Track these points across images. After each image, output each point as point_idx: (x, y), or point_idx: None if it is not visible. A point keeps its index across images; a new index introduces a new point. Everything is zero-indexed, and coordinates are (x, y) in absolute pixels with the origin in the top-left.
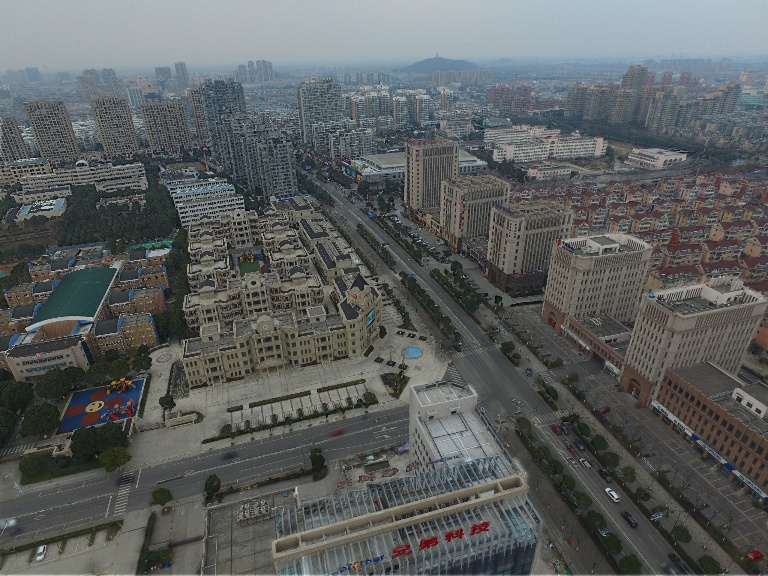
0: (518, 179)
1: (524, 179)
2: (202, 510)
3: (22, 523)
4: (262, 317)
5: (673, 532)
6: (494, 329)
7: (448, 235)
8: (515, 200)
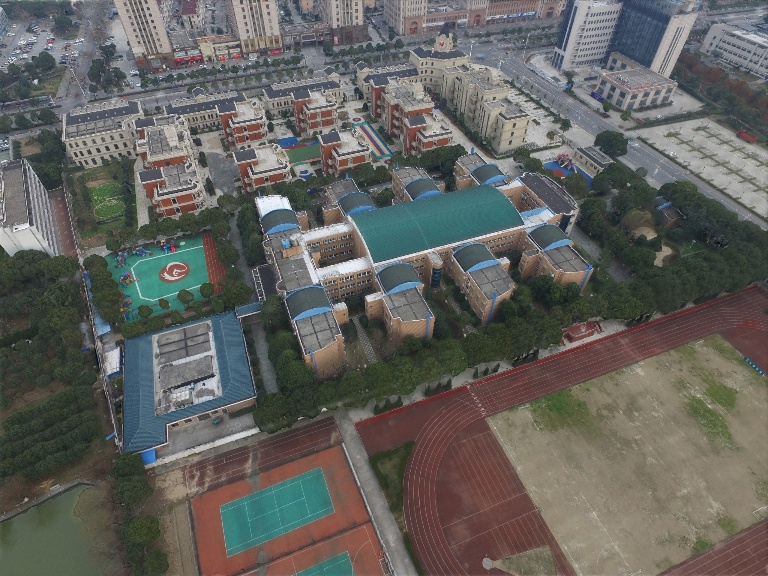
0: (59, 13)
1: (74, 8)
2: (613, 118)
3: (666, 169)
4: (492, 69)
5: (558, 28)
6: (434, 38)
7: (265, 41)
8: (190, 6)
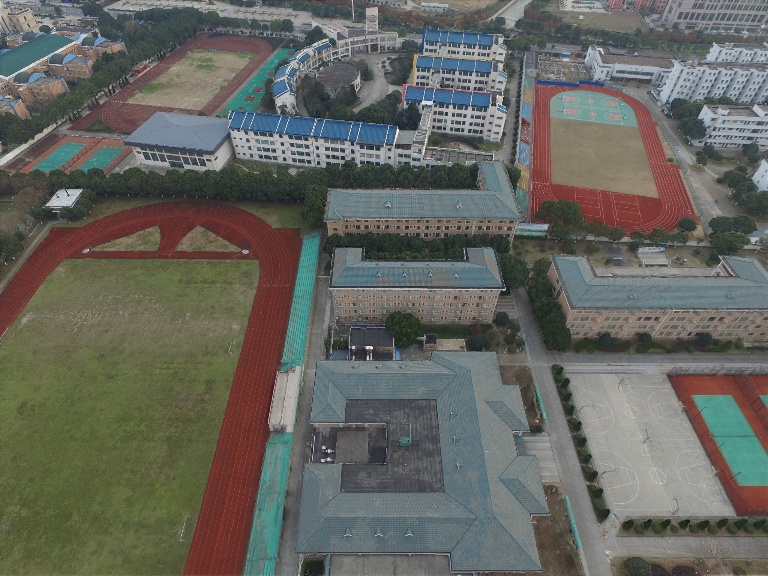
0: None
1: None
2: None
3: (133, 15)
4: None
5: None
6: None
7: None
8: None
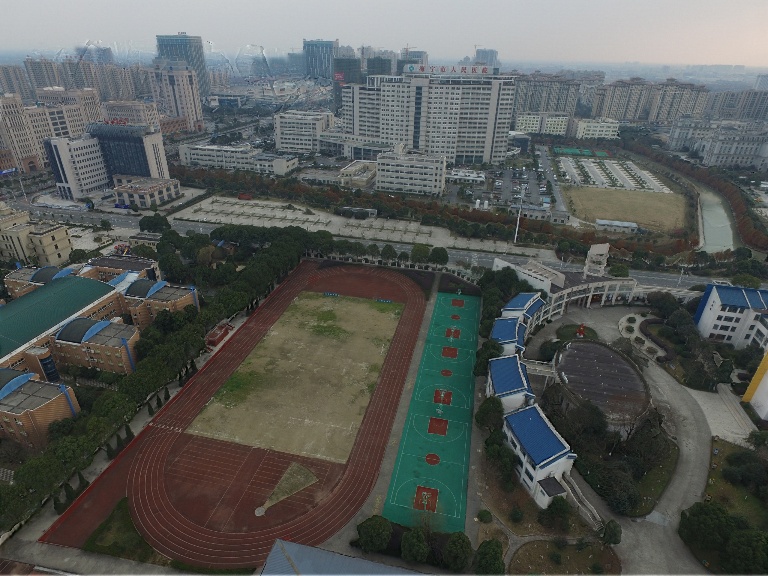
0: None
1: None
2: None
3: None
4: None
5: None
6: None
7: None
8: None
